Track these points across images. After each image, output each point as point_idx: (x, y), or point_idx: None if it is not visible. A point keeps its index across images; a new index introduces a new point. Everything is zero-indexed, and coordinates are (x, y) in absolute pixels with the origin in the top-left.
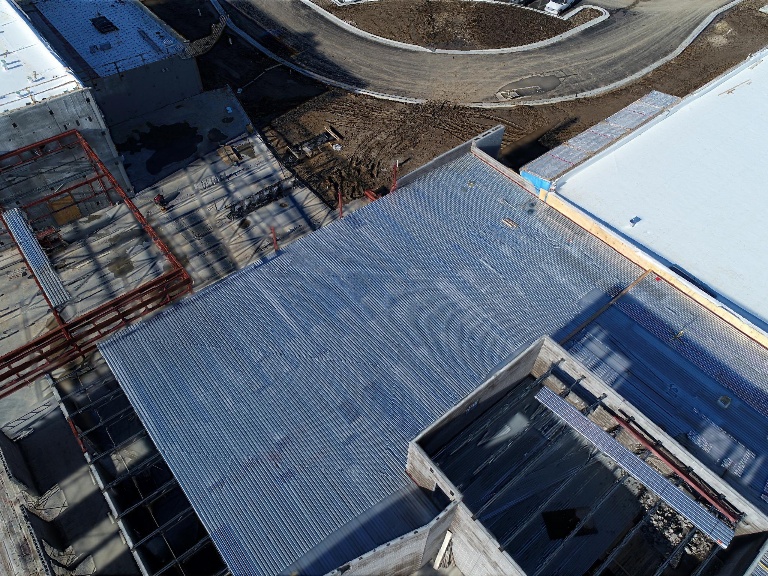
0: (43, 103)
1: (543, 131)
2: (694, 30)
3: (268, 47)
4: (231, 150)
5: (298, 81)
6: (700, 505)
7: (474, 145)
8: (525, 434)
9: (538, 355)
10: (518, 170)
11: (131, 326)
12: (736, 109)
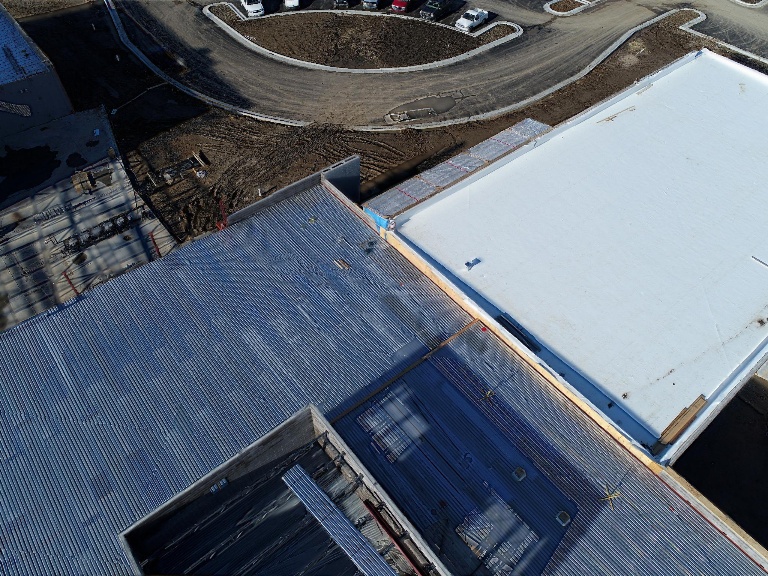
0: None
1: (424, 157)
2: (607, 49)
3: (158, 64)
4: (86, 177)
5: (179, 101)
6: None
7: (323, 177)
8: (293, 512)
9: (313, 423)
10: None
11: None
12: (612, 138)
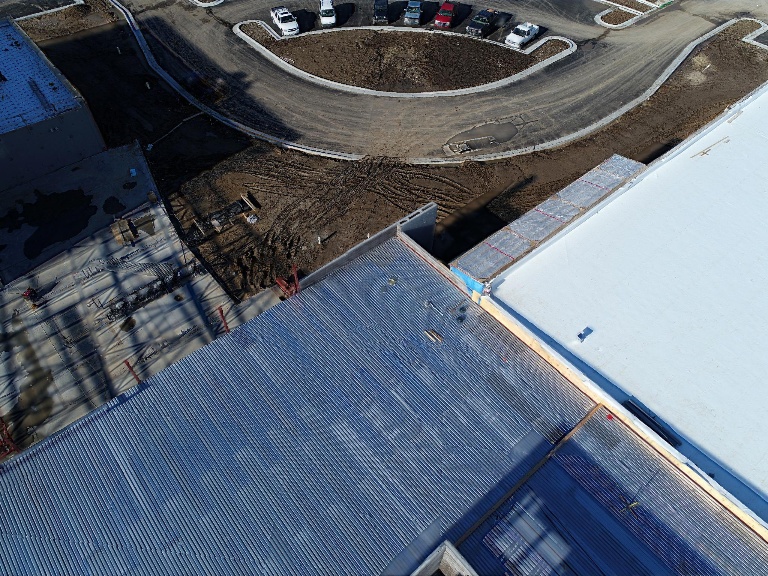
0: None
1: (493, 194)
2: (670, 65)
3: (191, 91)
4: (126, 225)
5: (219, 134)
6: None
7: (399, 229)
8: None
9: (442, 557)
10: (448, 264)
11: None
12: (711, 176)
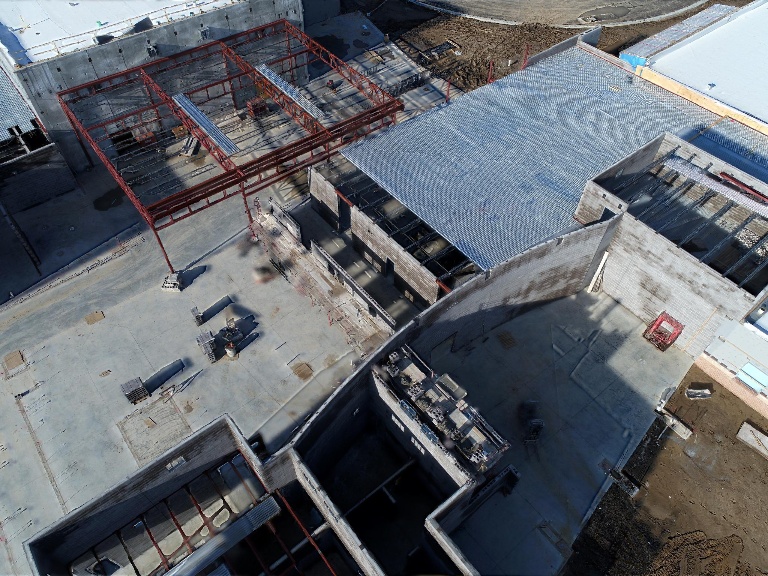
0: None
1: (621, 43)
2: None
3: None
4: (375, 53)
5: (414, 8)
6: None
7: (580, 39)
8: (650, 203)
9: (658, 151)
10: None
11: (358, 141)
12: None
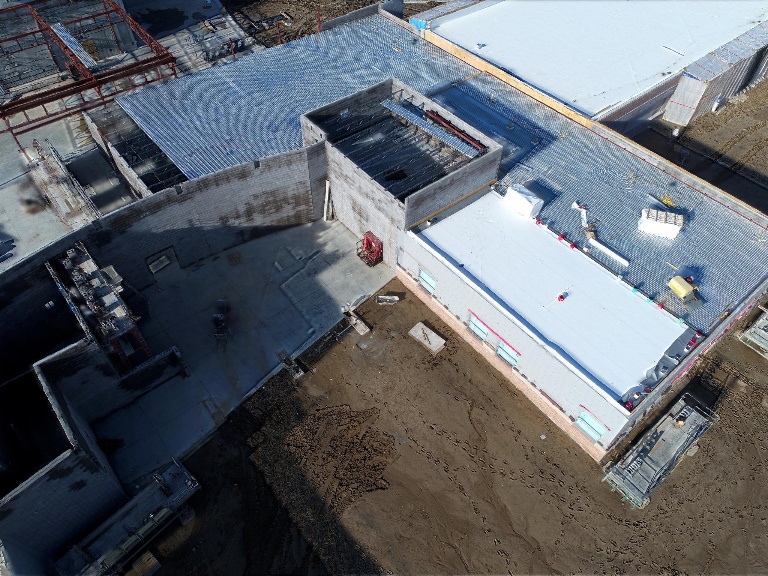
0: None
1: None
2: None
3: None
4: (209, 24)
5: None
6: (464, 143)
7: (380, 7)
8: None
9: (392, 96)
10: (408, 20)
11: (136, 91)
12: None
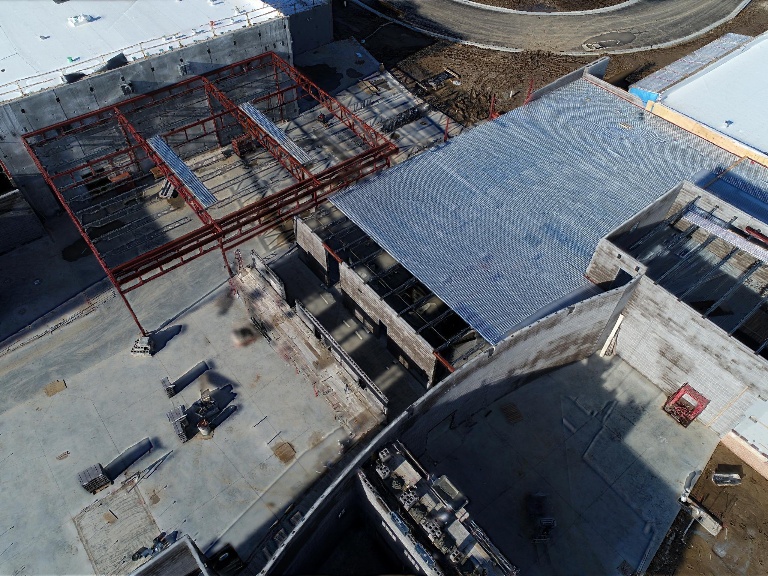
0: (256, 26)
1: (628, 72)
2: None
3: (377, 9)
4: (370, 84)
5: (411, 34)
6: None
7: (586, 71)
8: (667, 257)
9: (675, 200)
10: None
11: (349, 187)
12: None
